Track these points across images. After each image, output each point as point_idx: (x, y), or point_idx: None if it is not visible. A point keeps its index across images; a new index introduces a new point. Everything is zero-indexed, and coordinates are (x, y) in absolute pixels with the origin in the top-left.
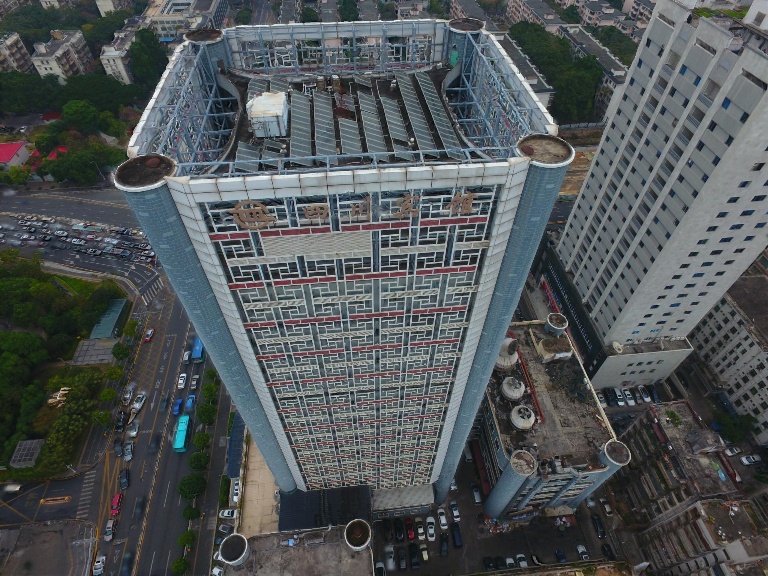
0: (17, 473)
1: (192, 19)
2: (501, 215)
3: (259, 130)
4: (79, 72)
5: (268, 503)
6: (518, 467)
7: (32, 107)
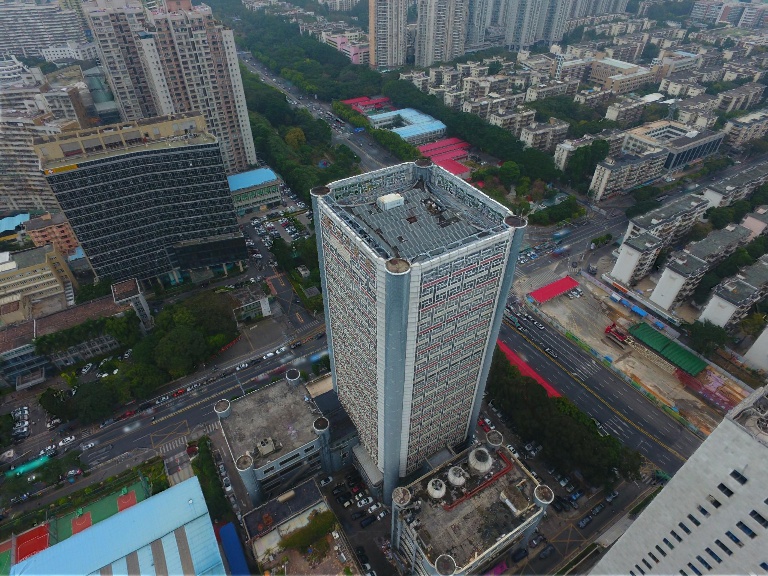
0: (303, 296)
1: (651, 148)
2: (378, 281)
3: (377, 204)
4: (544, 147)
5: (328, 390)
6: (396, 493)
7: (497, 154)
